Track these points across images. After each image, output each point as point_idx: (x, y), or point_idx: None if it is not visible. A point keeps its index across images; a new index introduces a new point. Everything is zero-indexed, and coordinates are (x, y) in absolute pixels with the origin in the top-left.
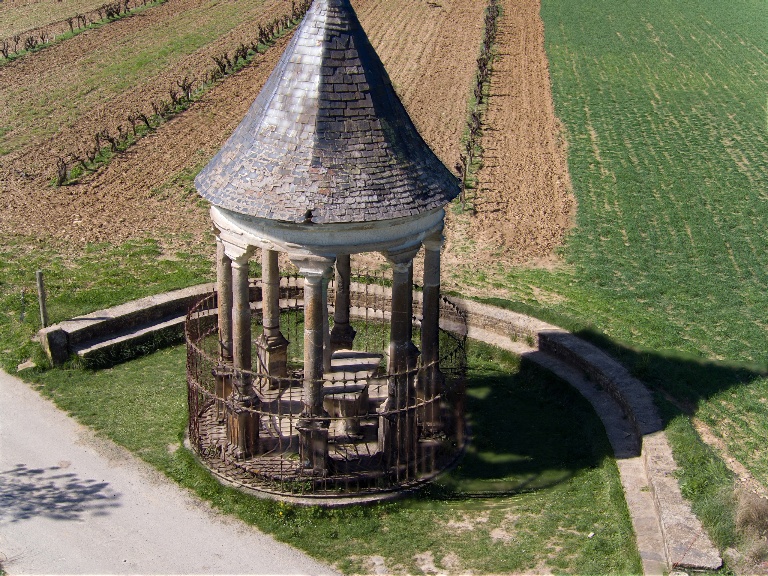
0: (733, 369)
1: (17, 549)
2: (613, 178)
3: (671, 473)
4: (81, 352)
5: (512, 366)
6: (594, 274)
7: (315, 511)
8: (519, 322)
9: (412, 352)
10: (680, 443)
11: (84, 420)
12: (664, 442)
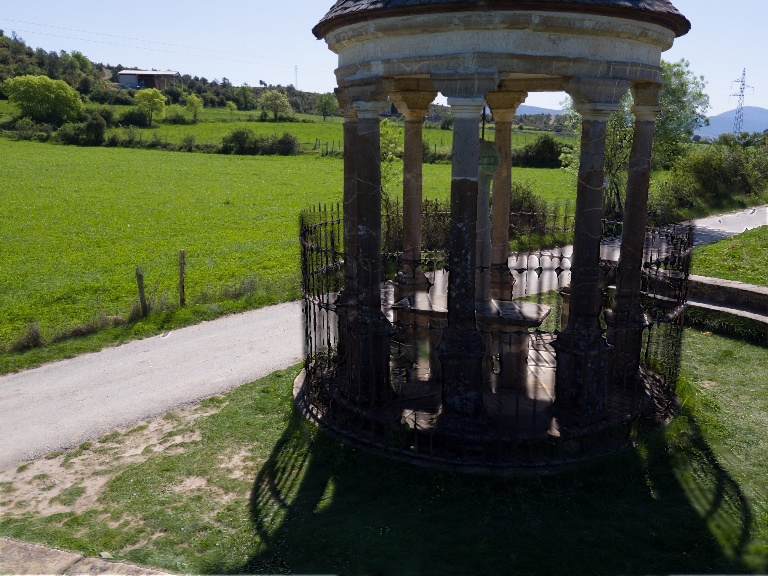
0: None
1: None
2: None
3: None
4: None
5: None
6: None
7: None
8: None
9: (571, 344)
10: None
11: None
12: None
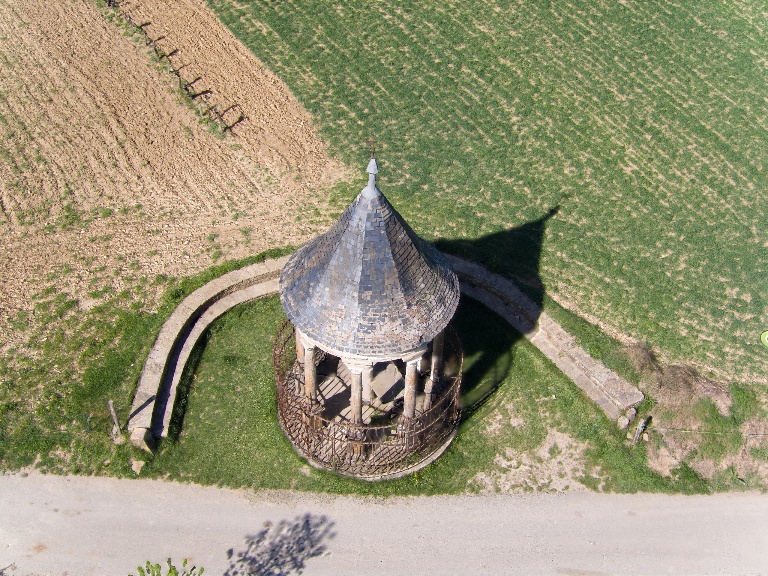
0: (526, 234)
1: None
2: (273, 32)
3: (574, 344)
4: (164, 435)
5: None
6: (378, 173)
7: (431, 468)
8: None
9: None
10: (562, 319)
11: (234, 486)
12: (551, 321)
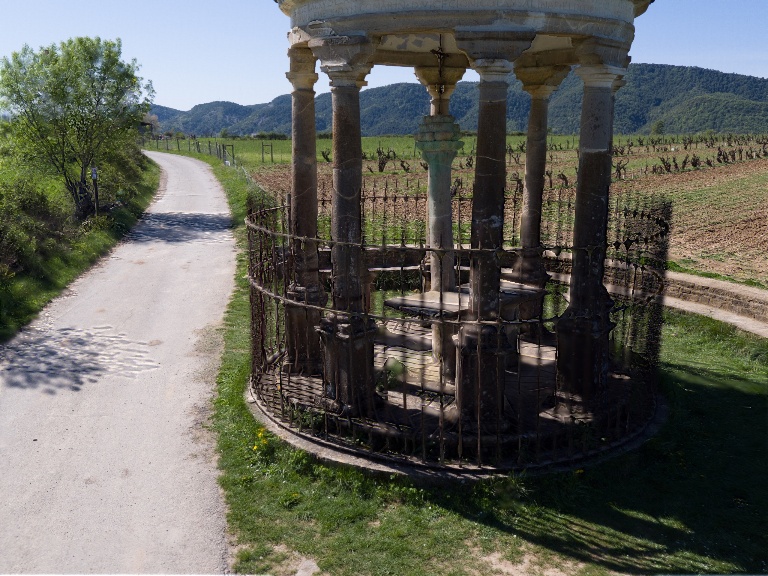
0: None
1: None
2: None
3: None
4: None
5: None
6: None
7: (296, 459)
8: None
9: None
10: None
11: (228, 317)
12: None
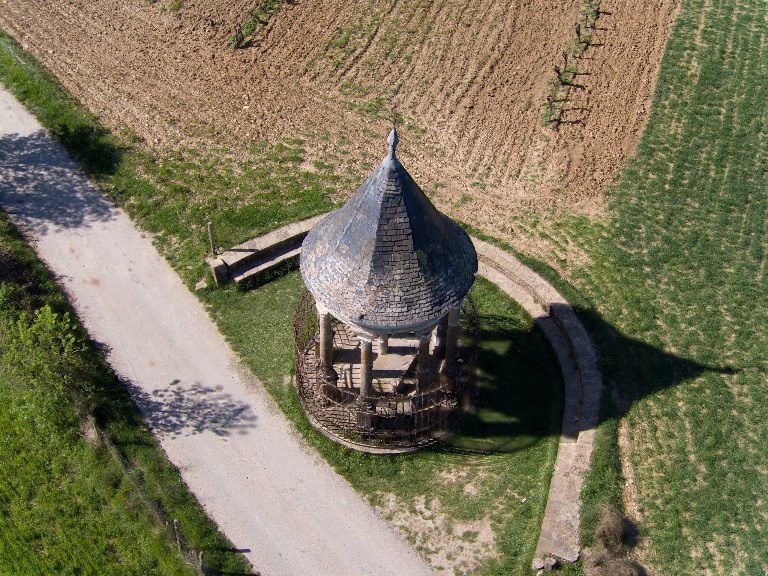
0: (676, 366)
1: (189, 460)
2: (697, 76)
3: (582, 473)
4: (236, 279)
5: (528, 325)
6: (621, 231)
7: (362, 455)
8: (541, 291)
9: None
10: (599, 446)
11: (234, 347)
12: (591, 441)
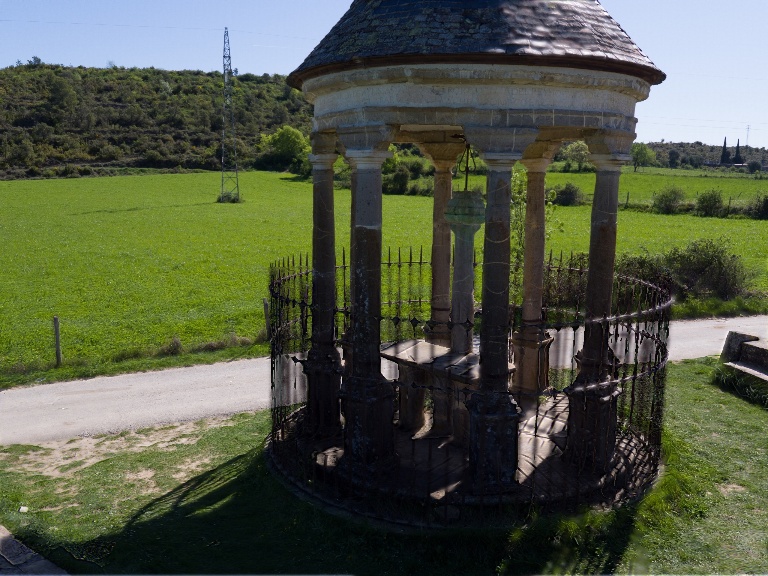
0: None
1: None
2: None
3: None
4: None
5: None
6: None
7: None
8: None
9: None
10: None
11: None
12: None
